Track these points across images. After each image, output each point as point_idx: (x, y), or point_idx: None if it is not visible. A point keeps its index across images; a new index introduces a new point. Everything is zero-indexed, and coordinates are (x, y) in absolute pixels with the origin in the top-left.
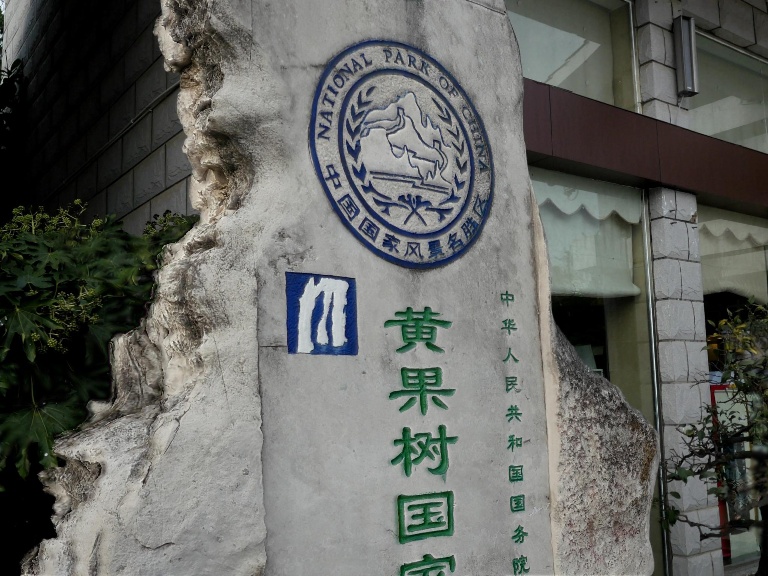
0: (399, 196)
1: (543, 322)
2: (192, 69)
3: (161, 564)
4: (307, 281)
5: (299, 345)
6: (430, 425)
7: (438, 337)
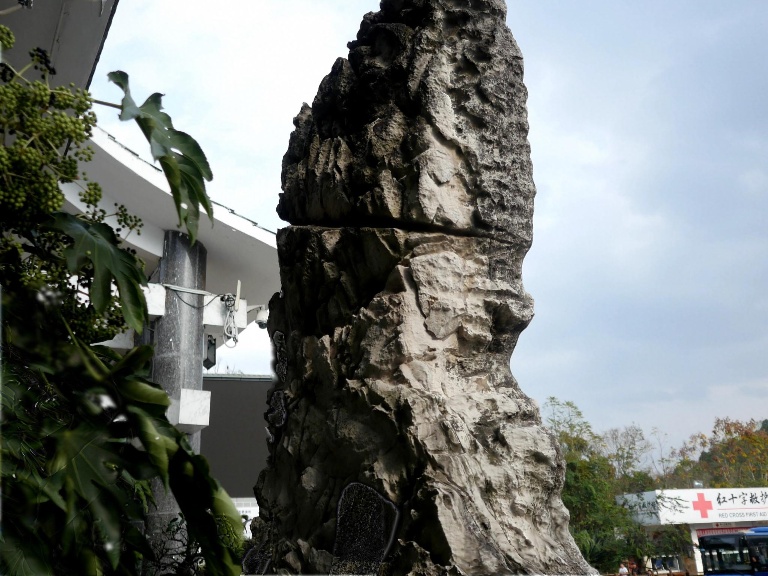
0: None
1: None
2: (461, 241)
3: None
4: None
5: None
6: None
7: None
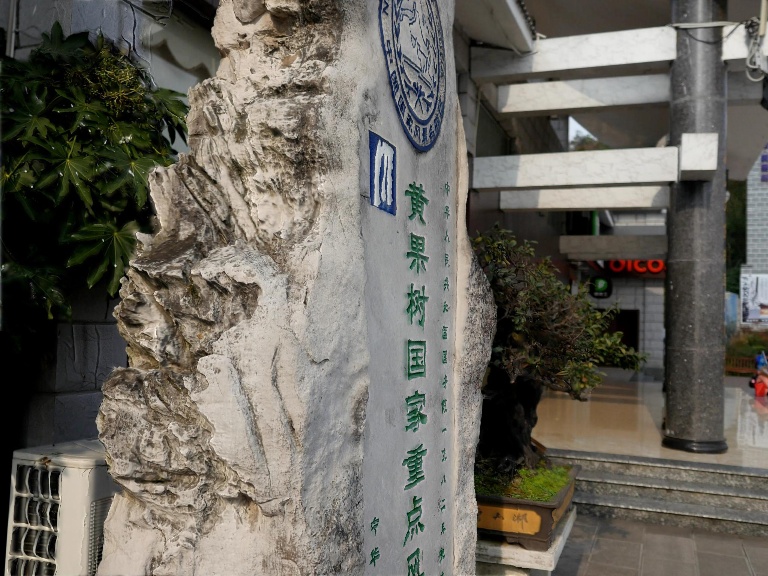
0: (413, 82)
1: (460, 213)
2: None
3: (322, 378)
4: (377, 142)
5: (375, 198)
6: (420, 284)
7: (424, 211)
